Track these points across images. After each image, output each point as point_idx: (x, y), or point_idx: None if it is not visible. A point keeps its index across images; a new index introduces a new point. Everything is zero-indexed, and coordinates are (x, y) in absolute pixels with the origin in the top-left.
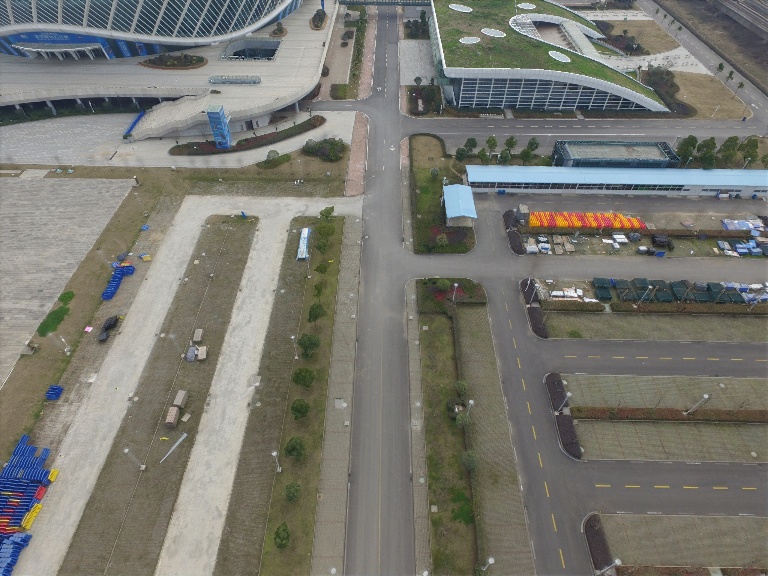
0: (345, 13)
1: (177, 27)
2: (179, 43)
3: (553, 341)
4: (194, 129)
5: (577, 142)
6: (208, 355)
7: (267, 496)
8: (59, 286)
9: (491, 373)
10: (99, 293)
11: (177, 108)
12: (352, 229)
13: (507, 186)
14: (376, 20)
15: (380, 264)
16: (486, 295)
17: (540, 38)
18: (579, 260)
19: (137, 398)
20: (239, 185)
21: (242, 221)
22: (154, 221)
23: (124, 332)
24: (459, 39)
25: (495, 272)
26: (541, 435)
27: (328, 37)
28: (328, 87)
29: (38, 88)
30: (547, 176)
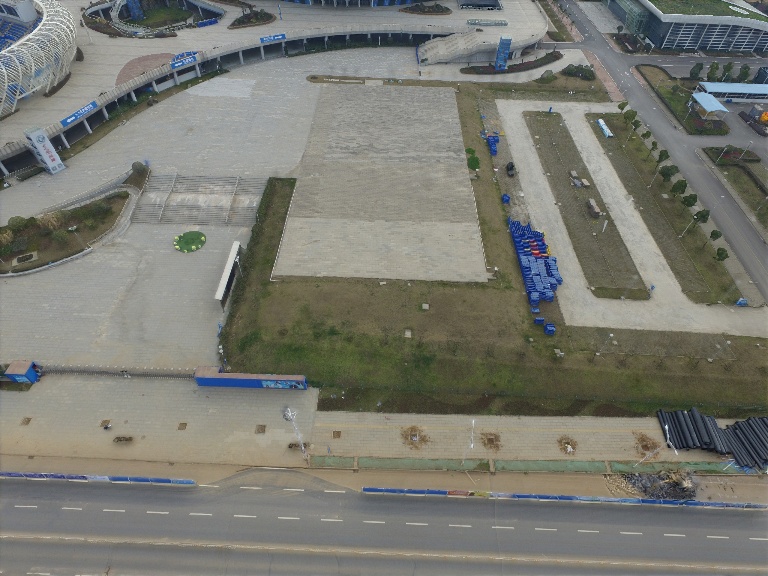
0: None
1: None
2: None
3: None
4: (472, 57)
5: None
6: None
7: (682, 248)
8: (460, 145)
9: None
10: (486, 151)
11: (451, 42)
12: None
13: (734, 96)
14: None
15: (669, 140)
16: None
17: None
18: None
19: (560, 204)
20: (528, 94)
21: (550, 115)
22: (486, 113)
23: (521, 172)
24: None
25: (754, 145)
26: None
27: None
28: None
29: (339, 25)
30: (764, 89)
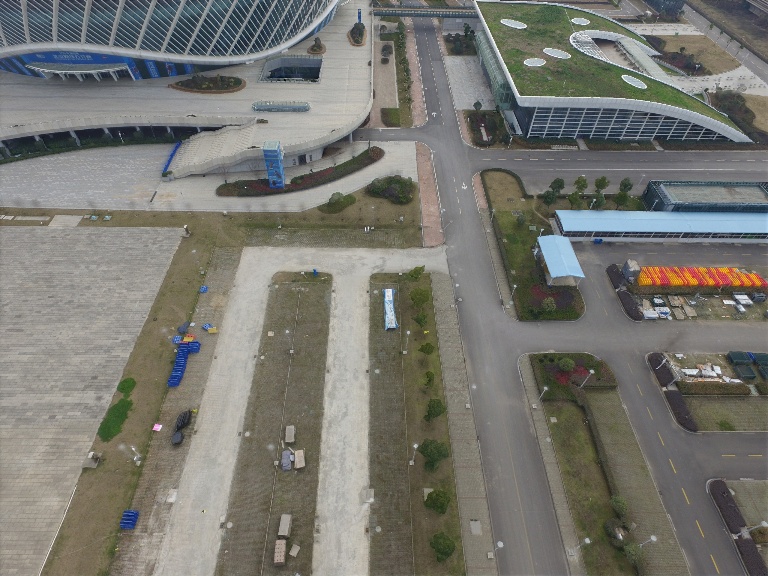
0: (379, 25)
1: (212, 45)
2: (212, 62)
3: (703, 435)
4: (242, 165)
5: (673, 182)
6: (306, 461)
7: None
8: (116, 371)
9: (644, 481)
10: (163, 378)
11: (220, 140)
12: (442, 289)
13: (605, 235)
14: (413, 33)
15: (483, 335)
16: (613, 375)
17: (607, 60)
18: (704, 327)
19: (231, 524)
20: (302, 233)
21: (314, 280)
22: (213, 280)
23: (200, 431)
24: (523, 61)
25: (615, 344)
26: (724, 567)
27: (372, 55)
28: (378, 112)
29: (60, 116)
30: (649, 224)
